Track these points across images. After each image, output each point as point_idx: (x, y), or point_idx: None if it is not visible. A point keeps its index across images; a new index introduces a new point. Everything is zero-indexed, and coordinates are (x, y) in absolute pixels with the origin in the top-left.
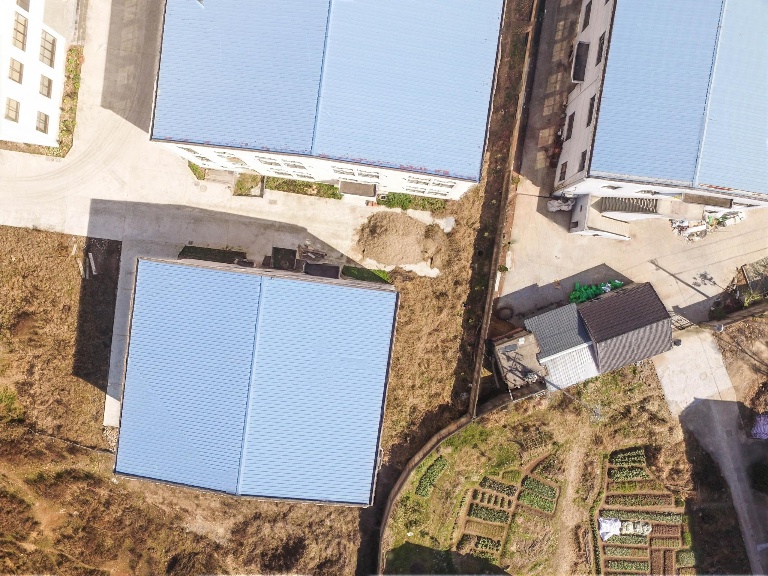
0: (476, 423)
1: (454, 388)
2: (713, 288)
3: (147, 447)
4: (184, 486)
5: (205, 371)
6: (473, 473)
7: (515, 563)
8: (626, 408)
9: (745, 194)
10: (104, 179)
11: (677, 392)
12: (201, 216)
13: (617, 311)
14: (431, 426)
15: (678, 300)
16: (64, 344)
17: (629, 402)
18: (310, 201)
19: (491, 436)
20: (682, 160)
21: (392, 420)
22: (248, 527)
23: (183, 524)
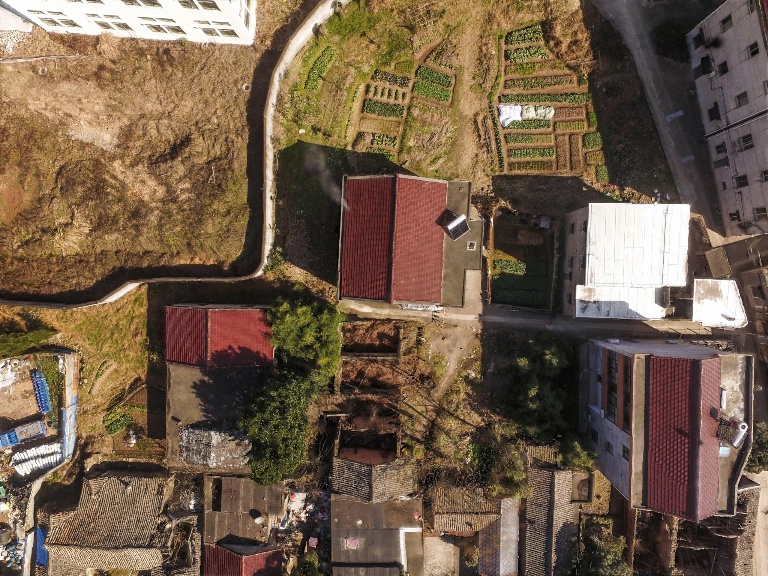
0: (362, 8)
1: None
2: None
3: None
4: None
5: None
6: (363, 63)
7: (413, 157)
8: None
9: None
10: None
11: None
12: None
13: None
14: None
15: None
16: None
17: None
18: None
19: (379, 22)
20: None
21: (273, 4)
22: (132, 126)
23: (68, 132)
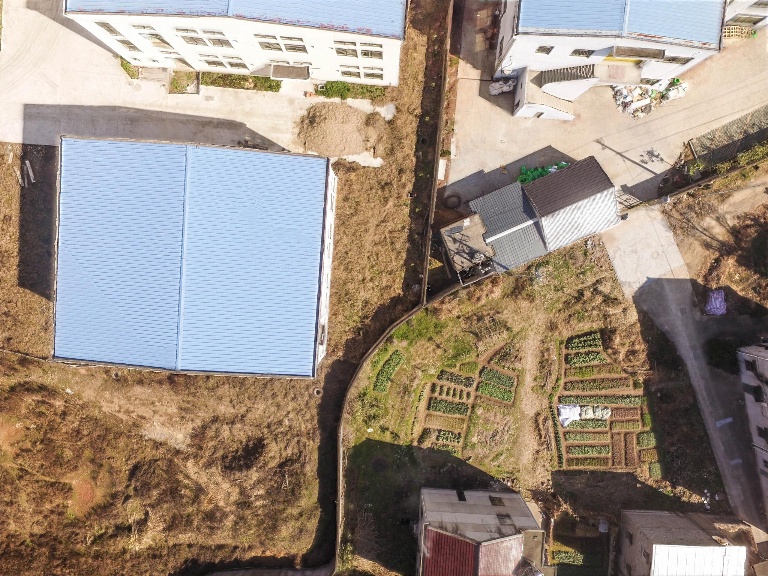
0: (430, 315)
1: (405, 280)
2: (661, 164)
3: (84, 329)
4: (123, 365)
5: (136, 247)
6: (430, 366)
7: (477, 454)
8: (579, 292)
9: (676, 42)
10: (36, 83)
11: (629, 272)
12: (137, 116)
13: (561, 185)
14: (384, 319)
15: (626, 179)
16: (8, 255)
17: (582, 285)
18: (247, 95)
19: (446, 328)
20: (610, 8)
21: (344, 315)
22: (206, 430)
23: (141, 432)
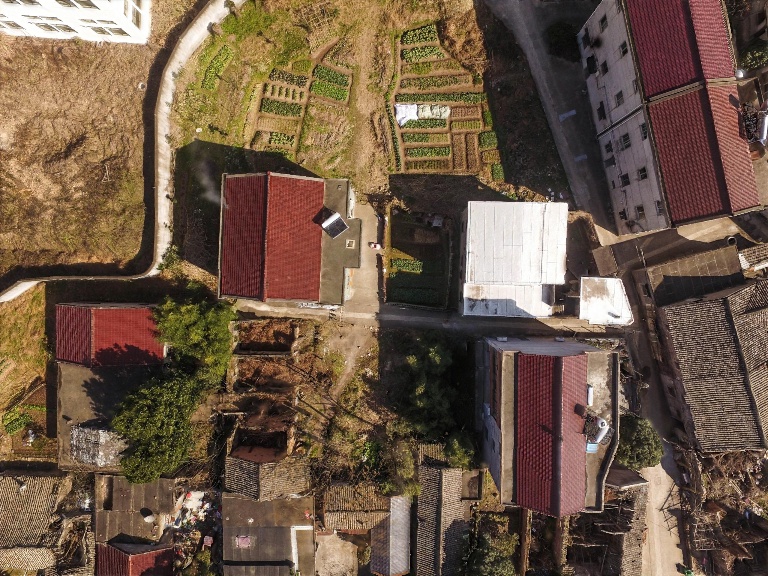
0: (258, 7)
1: None
2: None
3: None
4: None
5: None
6: (260, 62)
7: (310, 156)
8: None
9: None
10: None
11: None
12: None
13: None
14: None
15: None
16: None
17: None
18: None
19: (275, 21)
20: None
21: (167, 3)
22: (28, 124)
23: None
